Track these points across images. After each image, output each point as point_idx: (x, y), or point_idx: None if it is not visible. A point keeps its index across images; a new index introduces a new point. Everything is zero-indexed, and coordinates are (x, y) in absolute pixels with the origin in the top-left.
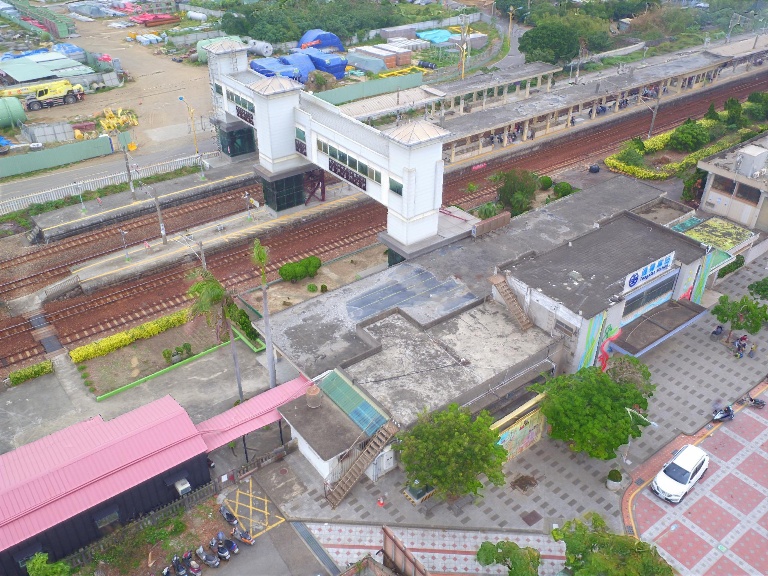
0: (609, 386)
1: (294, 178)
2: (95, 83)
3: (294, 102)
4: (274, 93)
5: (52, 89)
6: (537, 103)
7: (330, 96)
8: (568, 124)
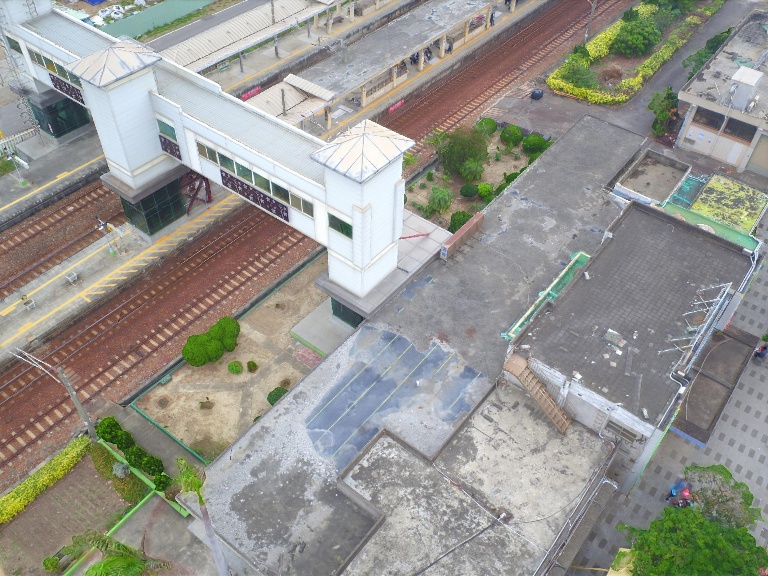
0: (728, 555)
1: (166, 186)
2: None
3: (148, 84)
4: (115, 80)
5: None
6: (452, 4)
7: (171, 7)
8: (487, 24)
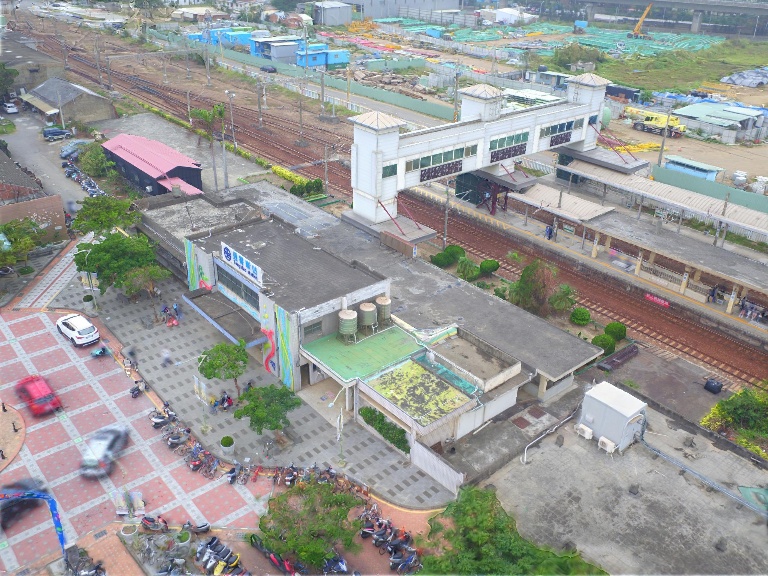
0: None
1: (471, 176)
2: (718, 135)
3: (481, 110)
4: (465, 93)
5: (659, 119)
6: None
7: None
8: None
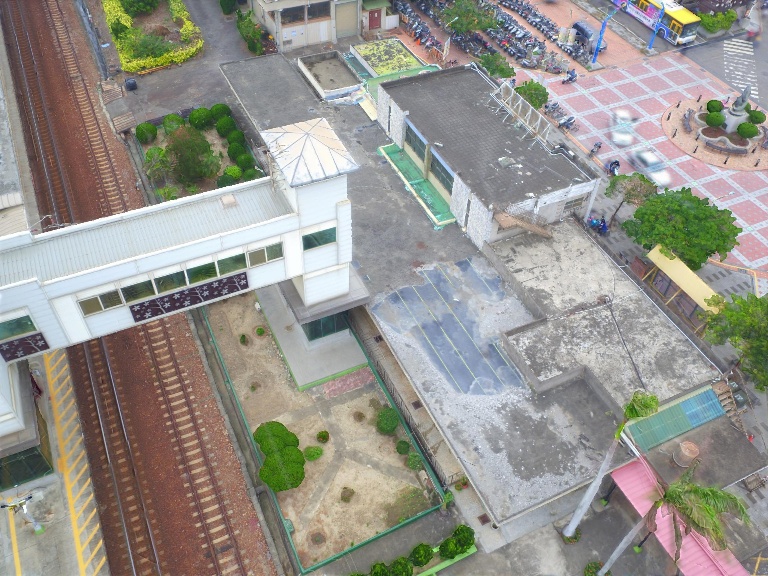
0: (690, 200)
1: None
2: None
3: None
4: None
5: None
6: None
7: None
8: None
